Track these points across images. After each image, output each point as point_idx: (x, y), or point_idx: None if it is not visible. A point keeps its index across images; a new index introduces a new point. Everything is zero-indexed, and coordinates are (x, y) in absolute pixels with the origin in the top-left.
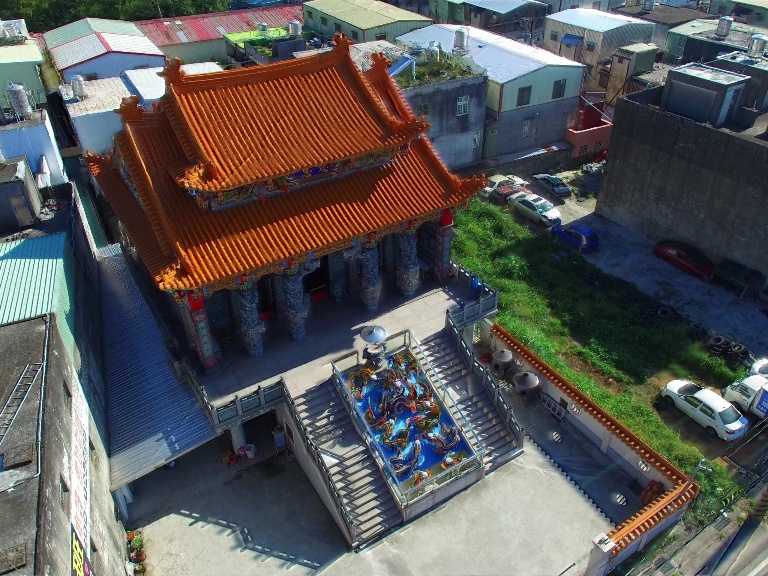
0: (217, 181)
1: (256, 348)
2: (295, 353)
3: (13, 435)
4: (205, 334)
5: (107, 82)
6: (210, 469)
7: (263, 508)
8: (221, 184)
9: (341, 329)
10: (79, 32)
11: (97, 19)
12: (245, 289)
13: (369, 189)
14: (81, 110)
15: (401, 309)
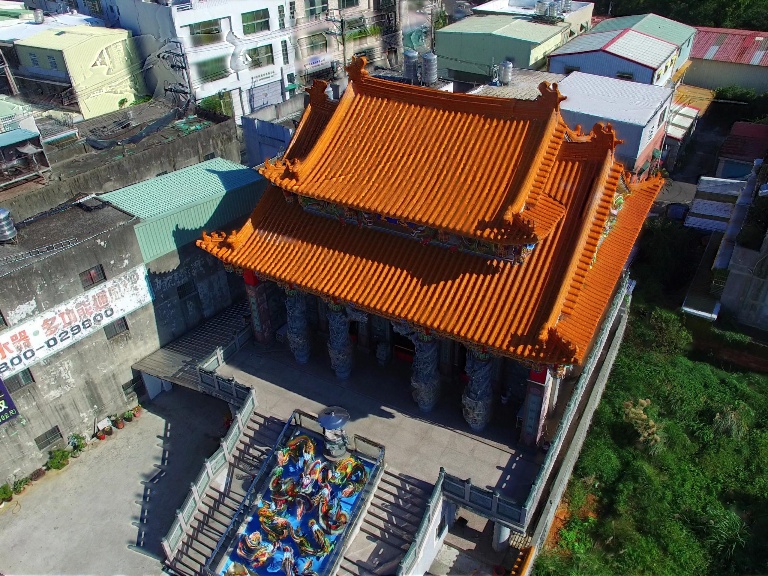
0: (296, 182)
1: (296, 354)
2: (318, 384)
3: (0, 268)
4: (256, 310)
5: (549, 77)
6: (215, 416)
7: (189, 473)
8: (293, 186)
9: (375, 399)
10: (621, 25)
11: (660, 17)
12: (287, 293)
13: (448, 274)
14: (484, 93)
15: (445, 431)
